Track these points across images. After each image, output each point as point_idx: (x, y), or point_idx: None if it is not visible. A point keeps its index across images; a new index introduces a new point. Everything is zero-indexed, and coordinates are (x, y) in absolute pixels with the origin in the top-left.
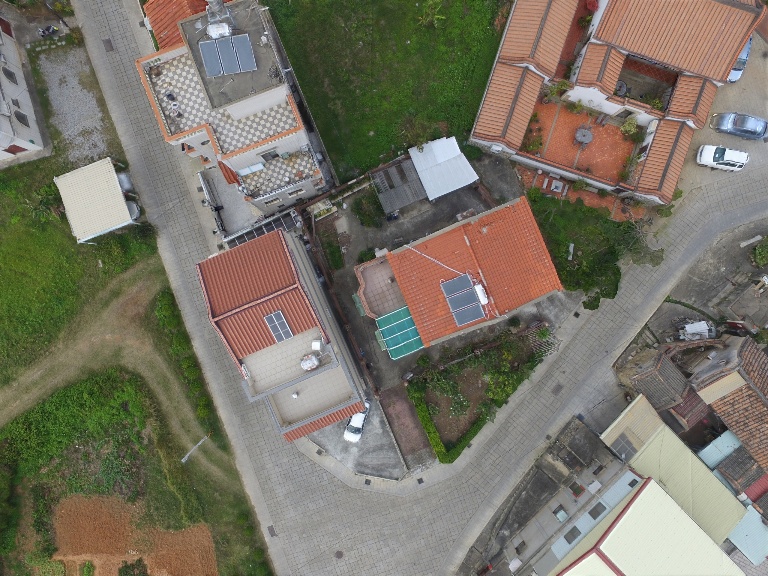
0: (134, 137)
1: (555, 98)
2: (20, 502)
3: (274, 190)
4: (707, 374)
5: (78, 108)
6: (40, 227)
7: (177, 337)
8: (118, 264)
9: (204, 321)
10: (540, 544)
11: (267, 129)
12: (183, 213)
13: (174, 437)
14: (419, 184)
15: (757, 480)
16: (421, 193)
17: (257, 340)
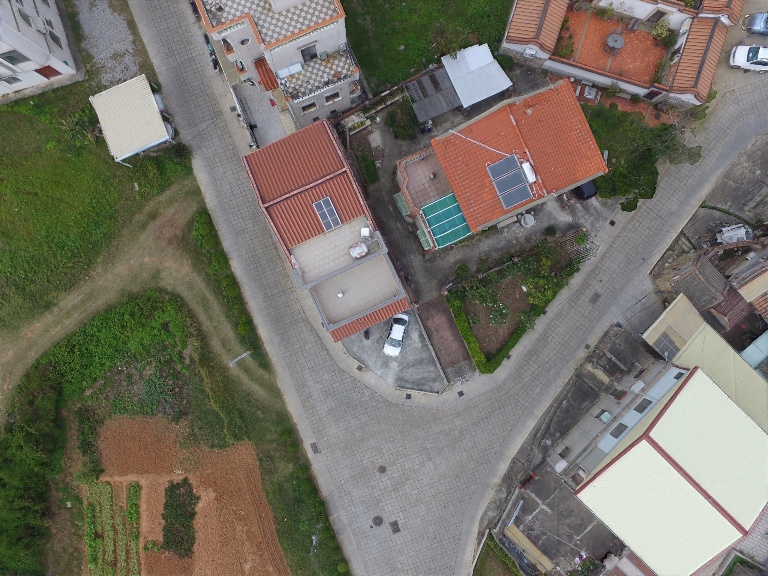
0: (166, 59)
1: (585, 5)
2: (65, 425)
3: (313, 91)
4: (747, 272)
5: (109, 31)
6: (76, 152)
7: (216, 255)
8: (154, 186)
9: (241, 241)
10: (585, 445)
11: (308, 21)
12: (217, 133)
13: (215, 356)
14: (453, 92)
15: None
16: (455, 101)
17: (306, 229)
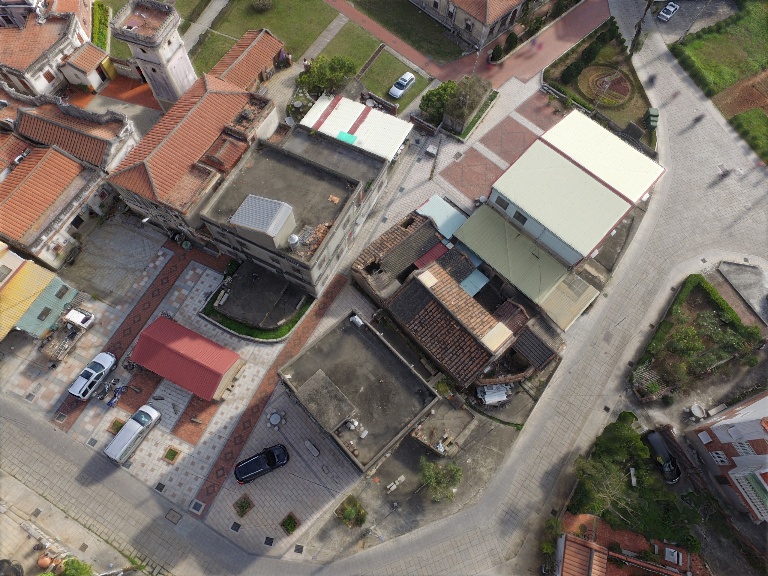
0: None
1: None
2: None
3: None
4: None
5: None
6: None
7: None
8: None
9: None
10: None
11: None
12: None
13: None
14: None
15: None
16: None
17: None
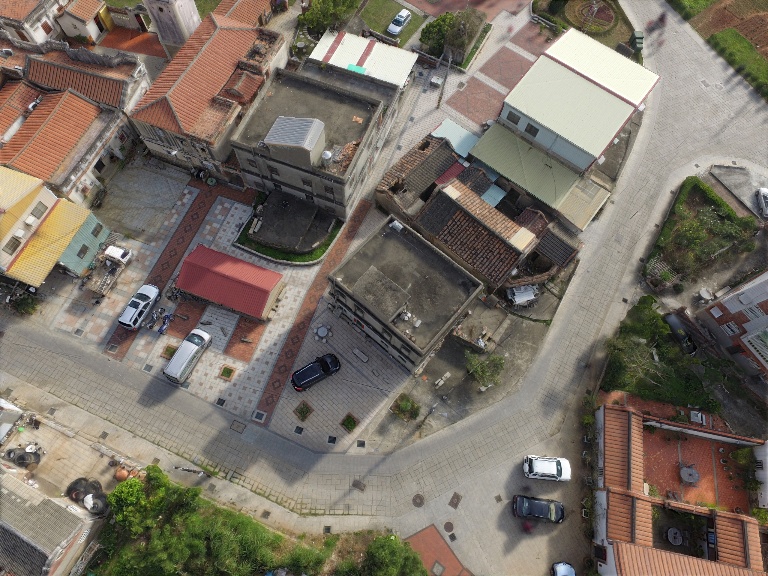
0: None
1: None
2: None
3: None
4: None
5: None
6: None
7: None
8: None
9: None
10: None
11: None
12: None
13: None
14: None
15: None
16: None
17: None
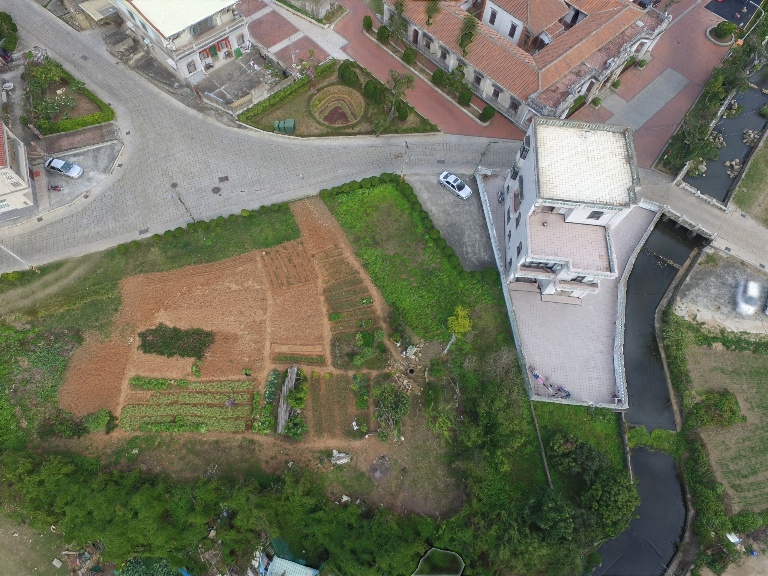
0: None
1: None
2: None
3: None
4: None
5: None
6: None
7: None
8: None
9: None
10: None
11: None
12: None
13: (34, 304)
14: None
15: None
16: None
17: None
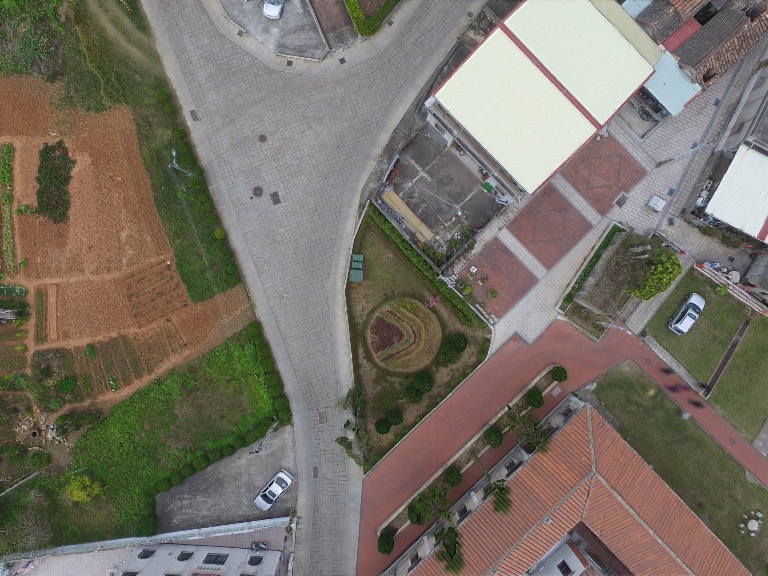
0: None
1: None
2: None
3: None
4: None
5: None
6: None
7: None
8: None
9: None
10: None
11: None
12: None
13: (92, 16)
14: None
15: (675, 32)
16: None
17: None
